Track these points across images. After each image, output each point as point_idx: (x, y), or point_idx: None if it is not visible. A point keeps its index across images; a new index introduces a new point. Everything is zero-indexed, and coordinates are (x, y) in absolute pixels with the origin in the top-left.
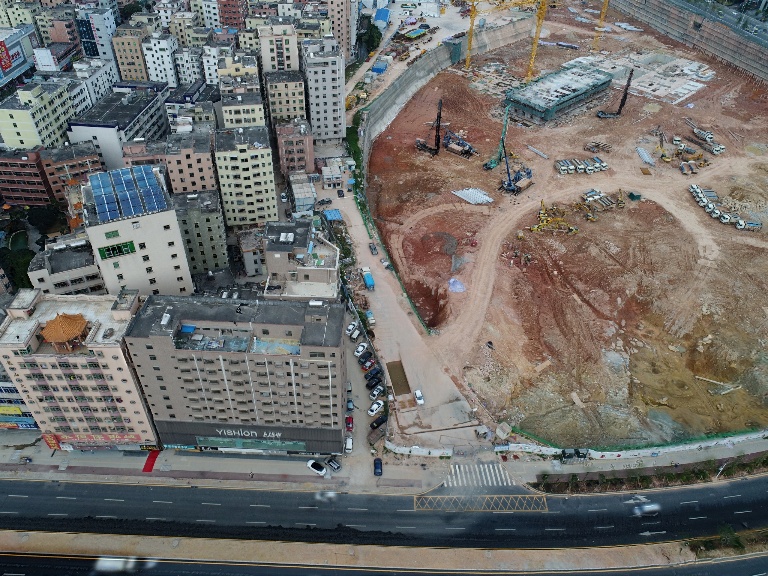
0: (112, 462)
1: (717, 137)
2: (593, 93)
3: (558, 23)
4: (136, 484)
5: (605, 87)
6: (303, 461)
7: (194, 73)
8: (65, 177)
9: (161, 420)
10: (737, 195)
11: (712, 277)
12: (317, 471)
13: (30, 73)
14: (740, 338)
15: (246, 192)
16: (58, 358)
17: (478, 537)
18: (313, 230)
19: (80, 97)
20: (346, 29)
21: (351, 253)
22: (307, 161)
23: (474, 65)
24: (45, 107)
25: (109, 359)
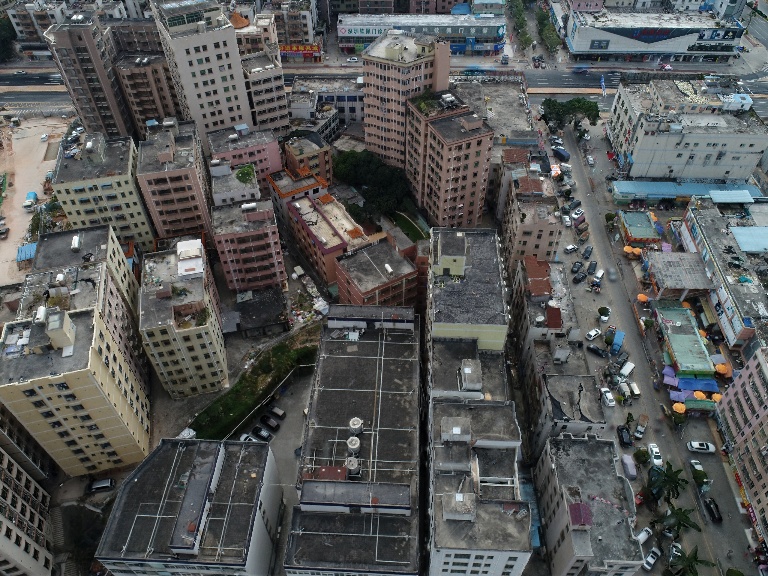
0: None
1: None
2: None
3: None
4: None
5: None
6: None
7: None
8: None
9: None
10: None
11: None
12: None
13: None
14: None
15: None
16: None
17: (54, 94)
18: None
19: None
20: None
21: None
22: None
23: None
24: None
25: None
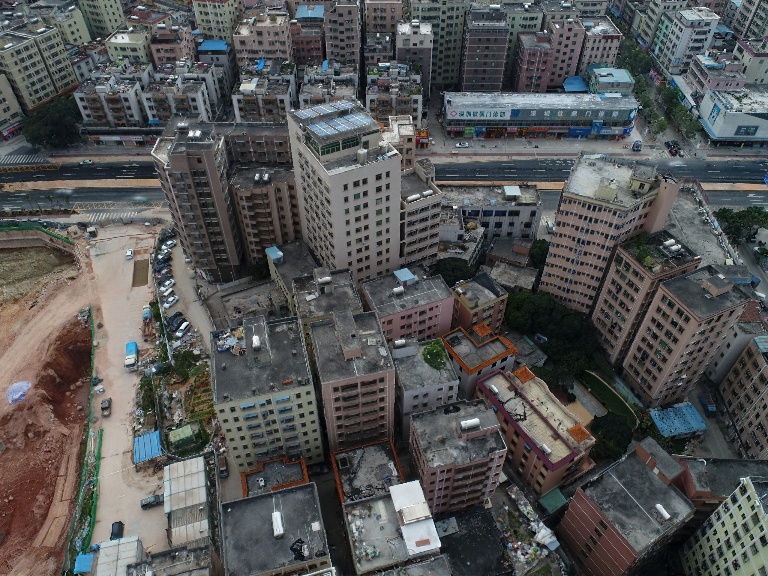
0: None
1: None
2: None
3: None
4: None
5: None
6: None
7: None
8: None
9: None
10: None
11: None
12: None
13: None
14: None
15: None
16: None
17: (129, 191)
18: None
19: None
20: None
21: None
22: None
23: None
24: None
25: None
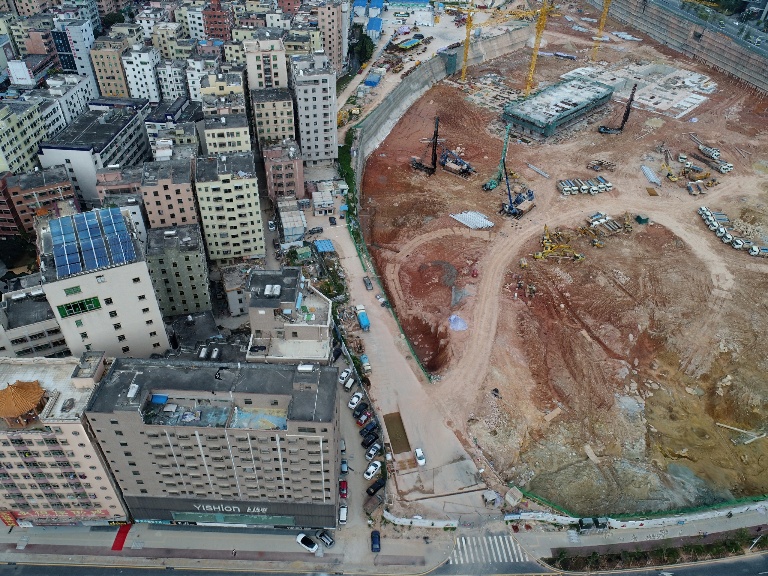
0: (77, 539)
1: (723, 154)
2: (594, 107)
3: (555, 32)
4: (104, 566)
5: (606, 100)
6: (292, 535)
7: (177, 87)
8: (34, 205)
9: (131, 496)
10: (748, 218)
11: (728, 310)
12: (308, 548)
13: (5, 86)
14: (761, 379)
15: (230, 224)
16: (9, 435)
17: None
18: (302, 279)
19: (53, 117)
20: (337, 40)
21: (344, 289)
22: (296, 186)
23: (470, 77)
24: (13, 129)
25: (69, 435)
